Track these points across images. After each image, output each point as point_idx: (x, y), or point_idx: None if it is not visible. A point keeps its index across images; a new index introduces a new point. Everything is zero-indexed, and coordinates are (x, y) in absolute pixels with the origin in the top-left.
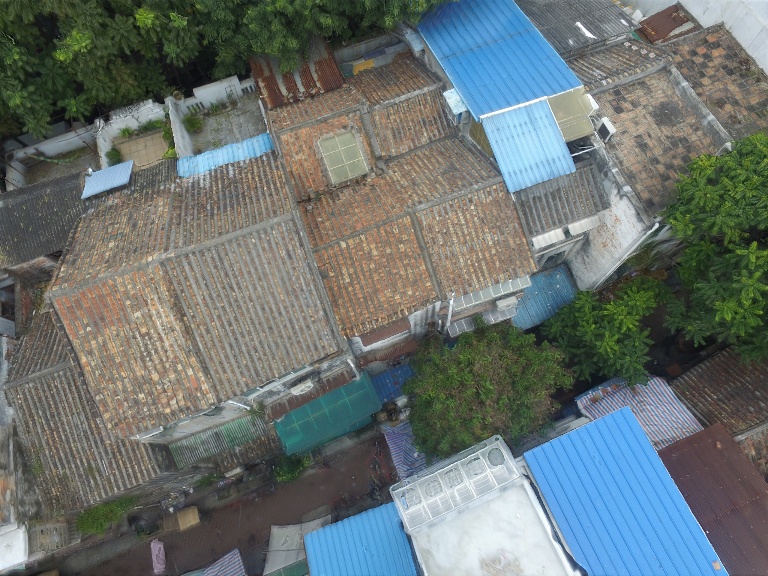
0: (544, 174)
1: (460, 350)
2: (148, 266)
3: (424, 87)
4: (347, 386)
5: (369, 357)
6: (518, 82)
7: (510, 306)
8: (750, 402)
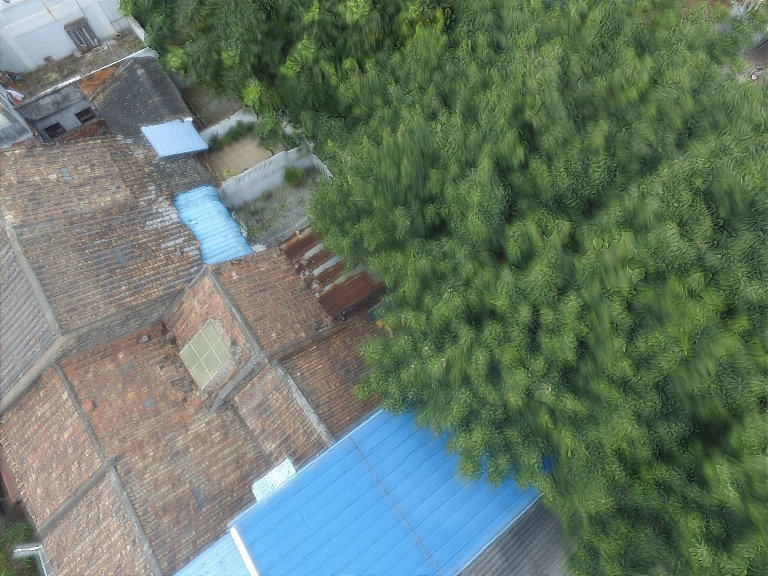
0: None
1: (19, 569)
2: (1, 219)
3: (329, 425)
4: None
5: None
6: (315, 575)
7: None
8: None
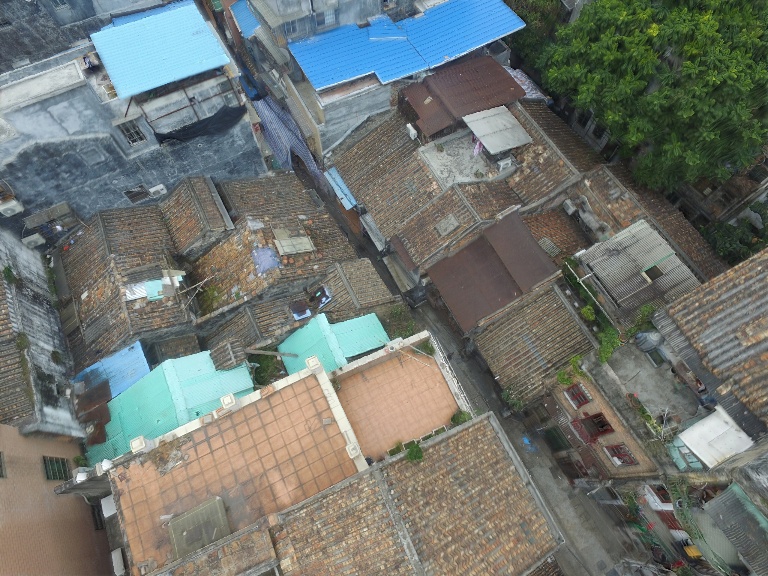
0: None
1: None
2: None
3: None
4: None
5: None
6: None
7: None
8: None
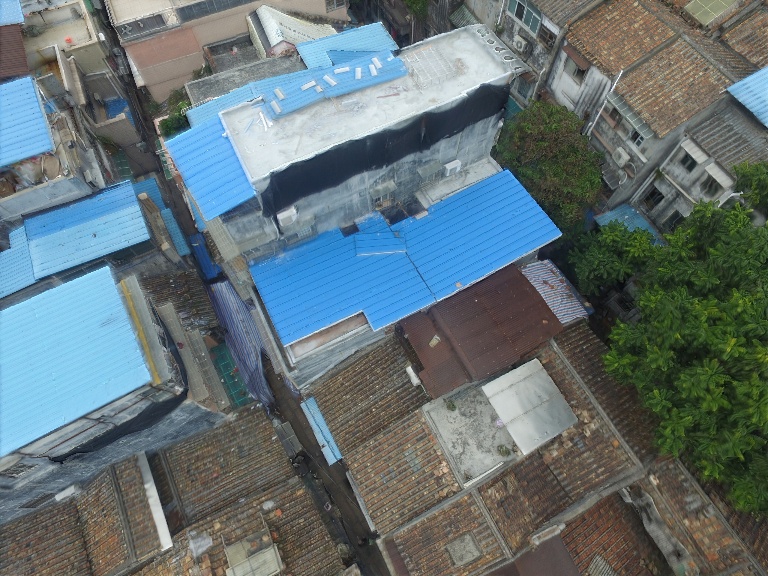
0: (757, 108)
1: None
2: None
3: None
4: (519, 109)
5: (548, 95)
6: None
7: (620, 161)
8: (589, 370)
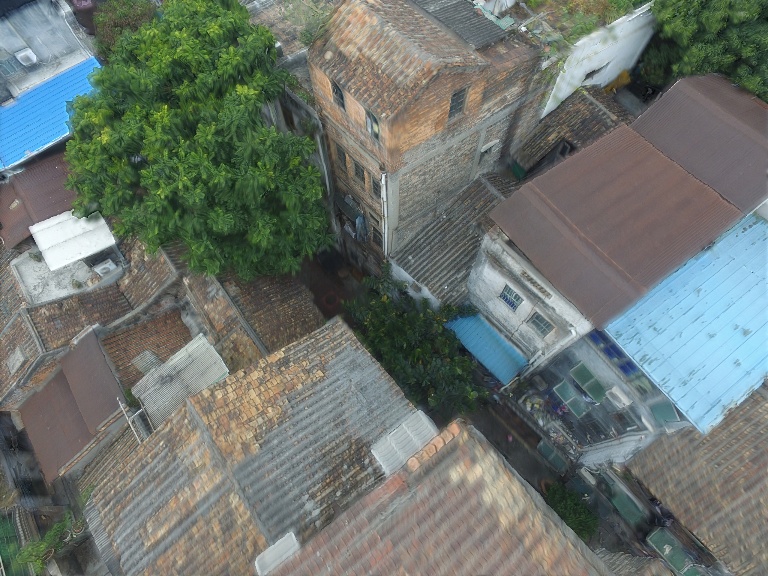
0: None
1: (147, 2)
2: None
3: None
4: None
5: None
6: None
7: None
8: None
